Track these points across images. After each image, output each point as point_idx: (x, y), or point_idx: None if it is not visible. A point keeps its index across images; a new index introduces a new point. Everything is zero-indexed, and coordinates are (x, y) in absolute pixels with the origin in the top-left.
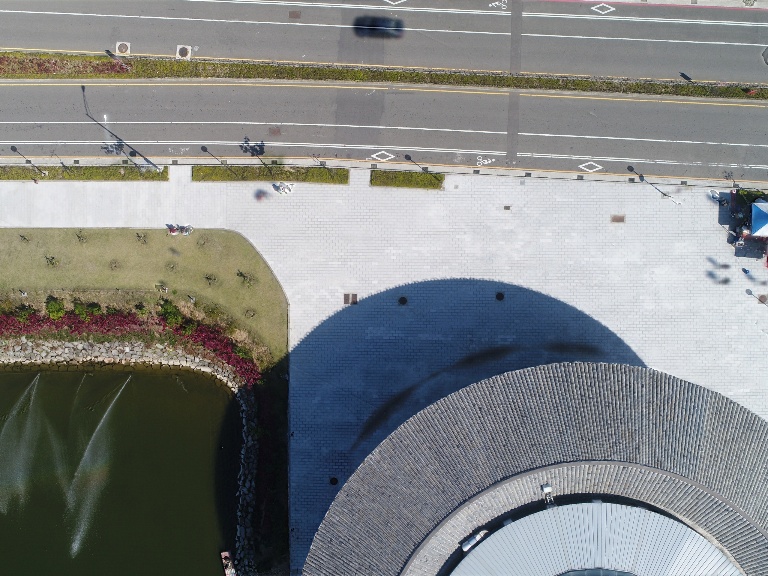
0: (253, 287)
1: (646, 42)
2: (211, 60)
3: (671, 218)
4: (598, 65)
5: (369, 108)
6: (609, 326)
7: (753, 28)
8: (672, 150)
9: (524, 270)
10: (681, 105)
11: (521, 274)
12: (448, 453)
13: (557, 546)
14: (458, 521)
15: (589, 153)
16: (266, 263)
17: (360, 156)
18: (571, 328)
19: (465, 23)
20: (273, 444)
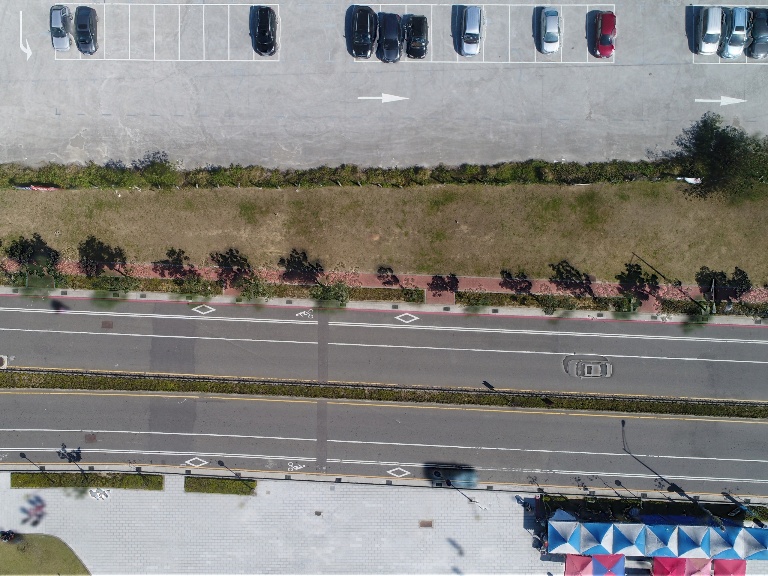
0: None
1: (449, 351)
2: (27, 369)
3: (477, 523)
4: (403, 374)
5: (181, 416)
6: None
7: (553, 337)
8: (477, 456)
9: (335, 575)
10: (484, 413)
11: None
12: None
13: None
14: None
15: (396, 459)
16: (85, 567)
17: (174, 462)
18: None
19: (273, 332)
20: None
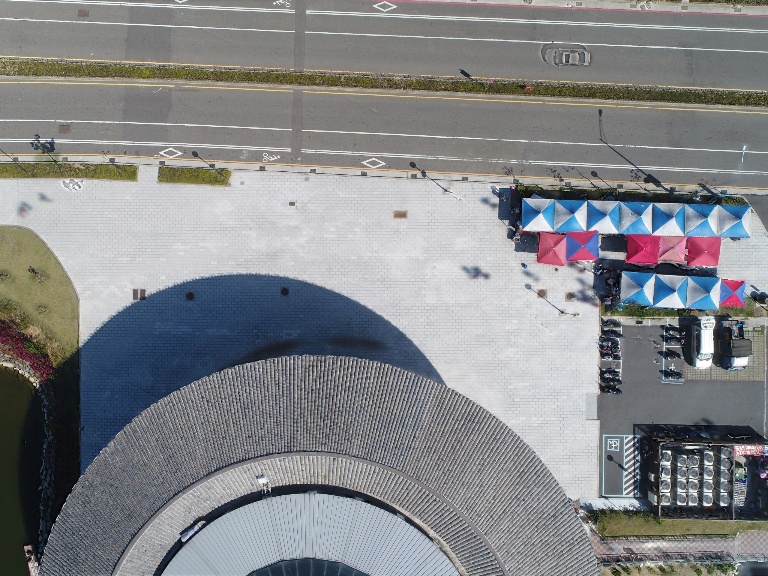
0: (44, 283)
1: (427, 39)
2: (1, 58)
3: (452, 214)
4: (380, 62)
5: (156, 105)
6: (391, 321)
7: (531, 25)
8: (453, 146)
9: (308, 265)
10: (461, 102)
11: (305, 269)
12: (172, 445)
13: (270, 536)
14: (175, 512)
15: (372, 149)
16: (57, 259)
17: (148, 153)
18: (354, 323)
19: (250, 21)
20: (67, 438)
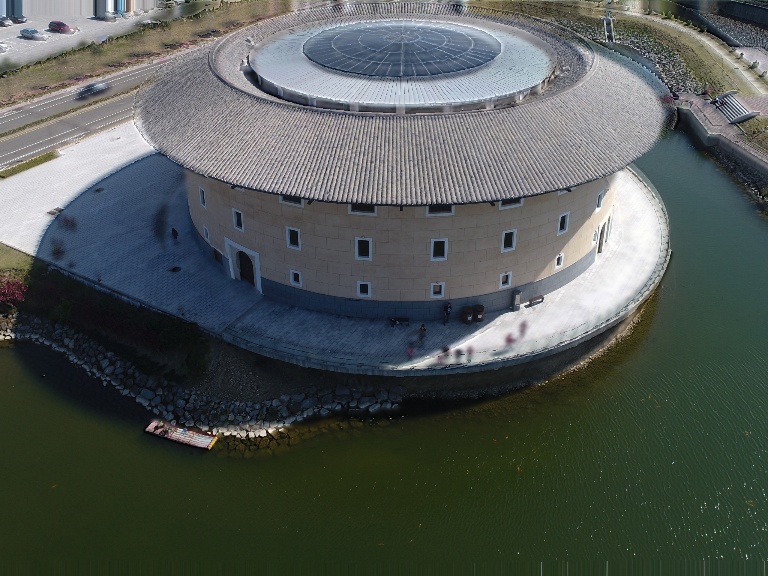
0: None
1: None
2: None
3: None
4: None
5: None
6: None
7: None
8: None
9: None
10: None
11: None
12: None
13: None
14: None
15: None
16: None
17: None
18: None
19: None
20: None
